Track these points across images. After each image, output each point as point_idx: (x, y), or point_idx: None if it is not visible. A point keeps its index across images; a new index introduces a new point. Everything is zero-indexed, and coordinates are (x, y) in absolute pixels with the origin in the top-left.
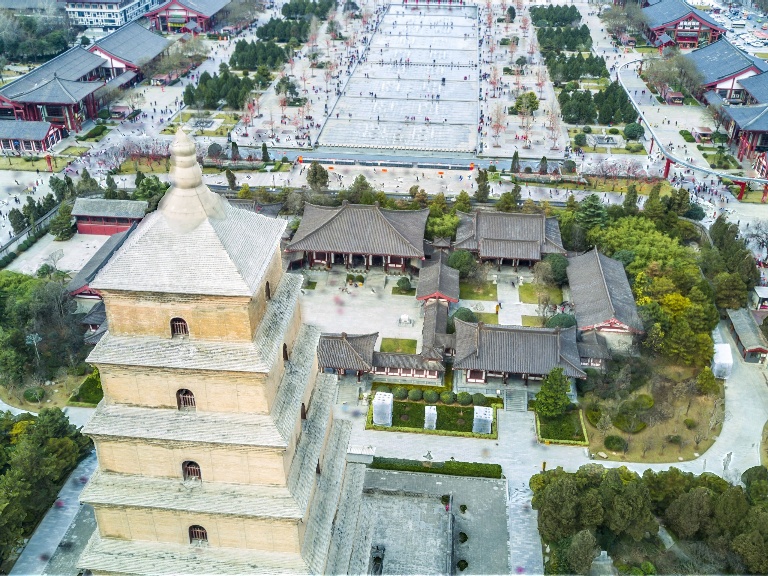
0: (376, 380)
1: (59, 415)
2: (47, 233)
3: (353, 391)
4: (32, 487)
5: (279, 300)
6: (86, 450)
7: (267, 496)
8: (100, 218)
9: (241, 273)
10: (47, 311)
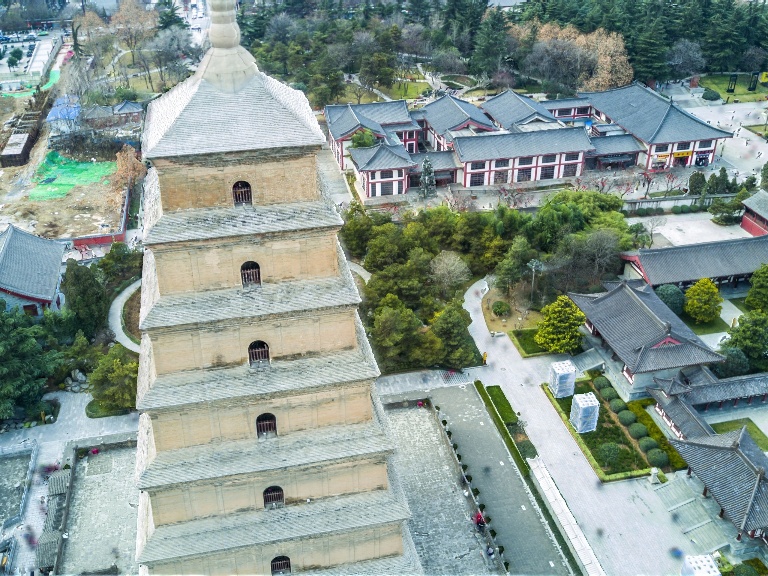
0: (767, 560)
1: (453, 320)
2: (707, 208)
3: (717, 540)
4: (376, 348)
5: (263, 213)
6: (453, 364)
7: (150, 372)
8: (764, 219)
9: (166, 137)
10: (583, 255)
